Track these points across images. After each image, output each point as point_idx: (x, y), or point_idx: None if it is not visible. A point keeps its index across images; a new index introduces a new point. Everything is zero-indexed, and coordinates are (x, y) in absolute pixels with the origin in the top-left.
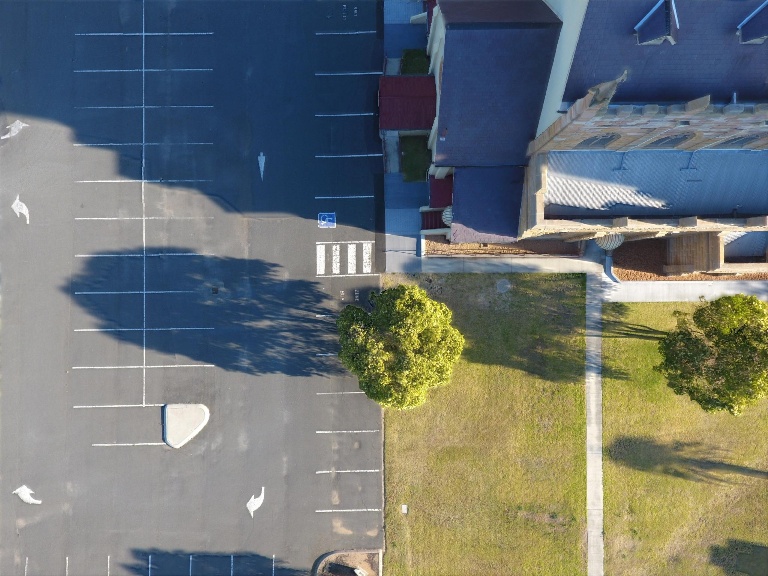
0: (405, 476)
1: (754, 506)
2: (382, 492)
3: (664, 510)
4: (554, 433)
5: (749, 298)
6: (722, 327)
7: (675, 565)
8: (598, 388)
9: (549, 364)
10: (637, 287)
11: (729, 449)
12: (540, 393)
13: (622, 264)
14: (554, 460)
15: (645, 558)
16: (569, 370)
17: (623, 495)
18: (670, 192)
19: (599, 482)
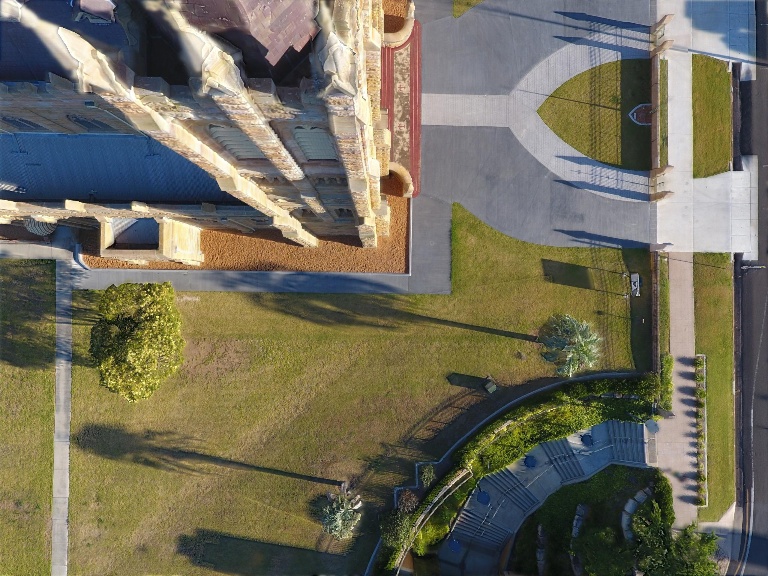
0: None
1: (224, 496)
2: None
3: (132, 499)
4: (22, 420)
5: (147, 285)
6: (104, 313)
7: (141, 554)
8: (68, 375)
9: (19, 350)
10: (109, 275)
11: (202, 439)
12: (9, 379)
13: (93, 251)
14: (21, 447)
15: (111, 547)
16: (39, 357)
17: (90, 483)
18: (16, 176)
19: (65, 470)
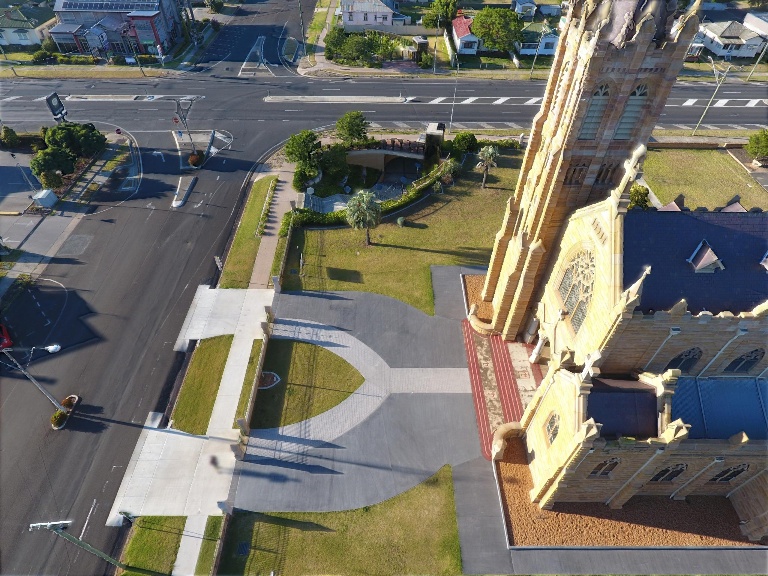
0: (760, 196)
1: None
2: (767, 191)
3: None
4: None
5: None
6: None
7: None
8: None
9: None
10: None
11: None
12: None
13: None
14: None
15: None
16: None
17: None
18: None
19: None
